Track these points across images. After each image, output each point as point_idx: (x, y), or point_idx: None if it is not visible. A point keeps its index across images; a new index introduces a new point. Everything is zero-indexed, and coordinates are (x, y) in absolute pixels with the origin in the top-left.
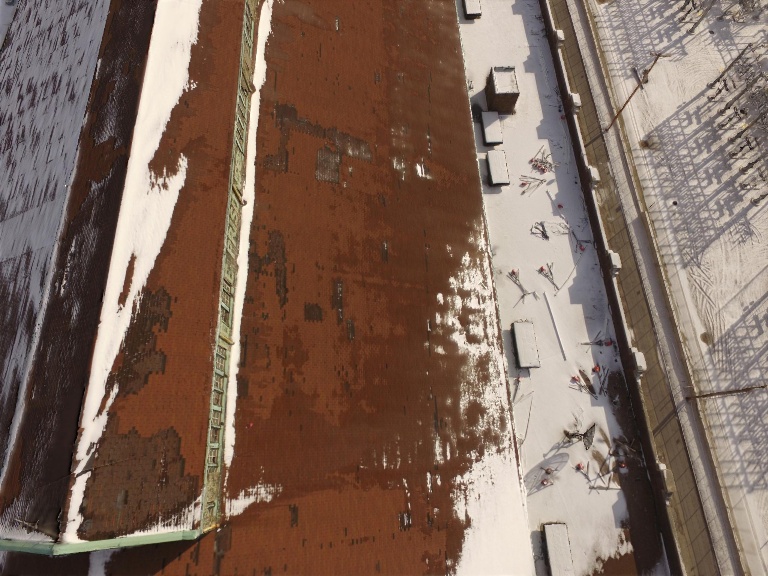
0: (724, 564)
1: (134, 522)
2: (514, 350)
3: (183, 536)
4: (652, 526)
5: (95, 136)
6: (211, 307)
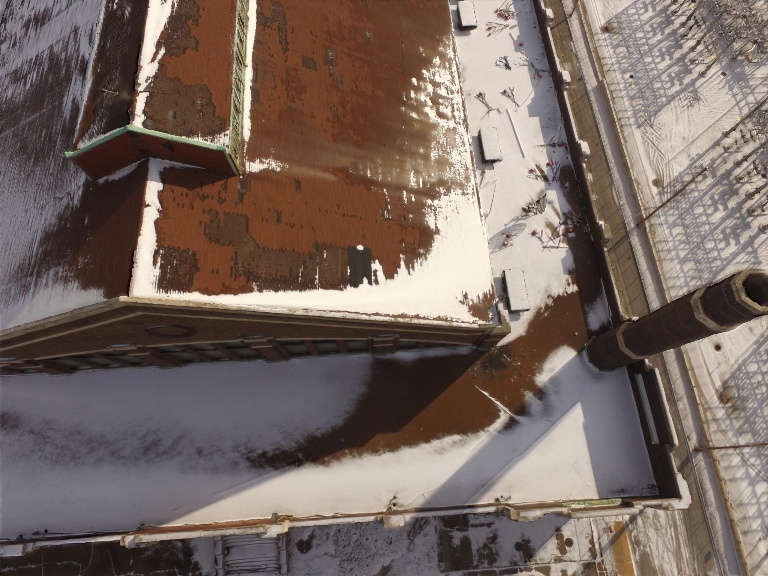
0: None
1: (181, 131)
2: (480, 150)
3: (217, 147)
4: (594, 273)
5: None
6: (230, 21)
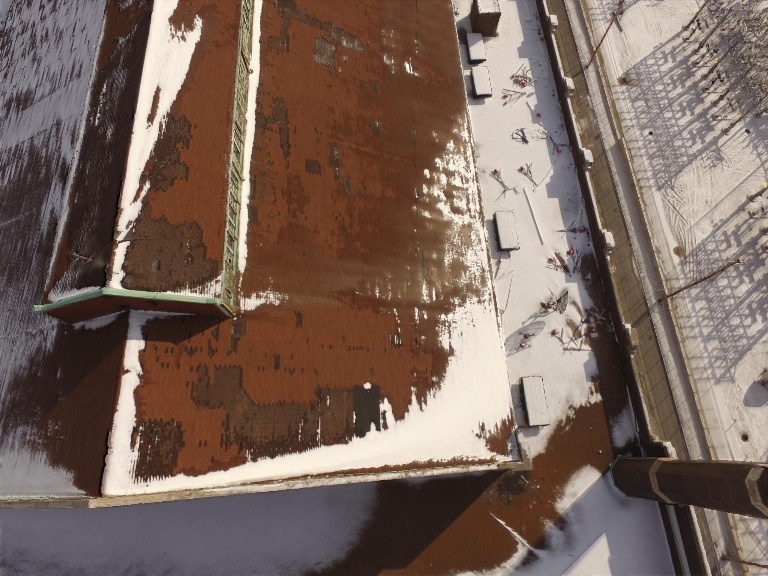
0: (691, 441)
1: (166, 284)
2: (496, 236)
3: (207, 300)
4: (619, 380)
5: (120, 4)
6: (225, 137)
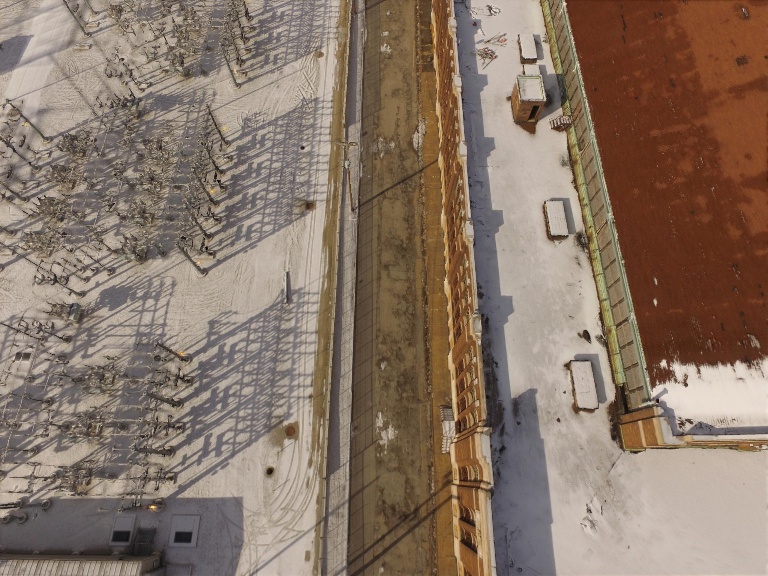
0: None
1: None
2: None
3: None
4: None
5: None
6: None
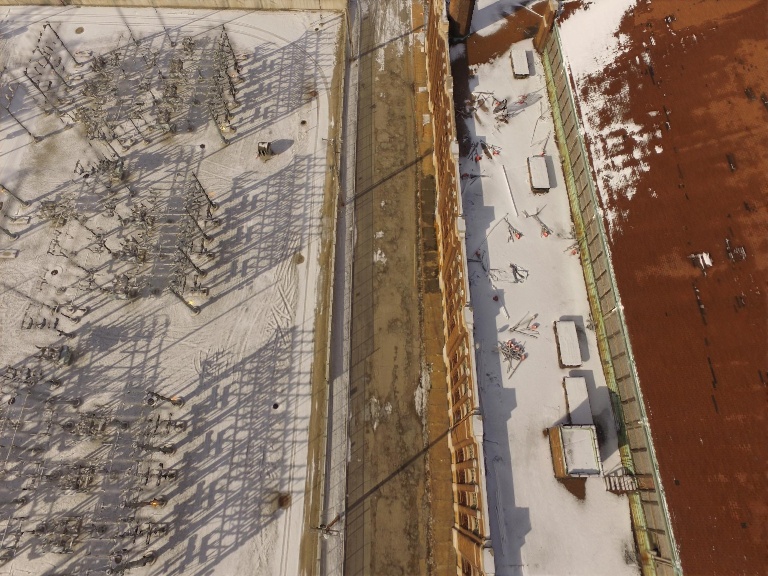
0: (353, 113)
1: None
2: None
3: None
4: (454, 75)
5: None
6: None
